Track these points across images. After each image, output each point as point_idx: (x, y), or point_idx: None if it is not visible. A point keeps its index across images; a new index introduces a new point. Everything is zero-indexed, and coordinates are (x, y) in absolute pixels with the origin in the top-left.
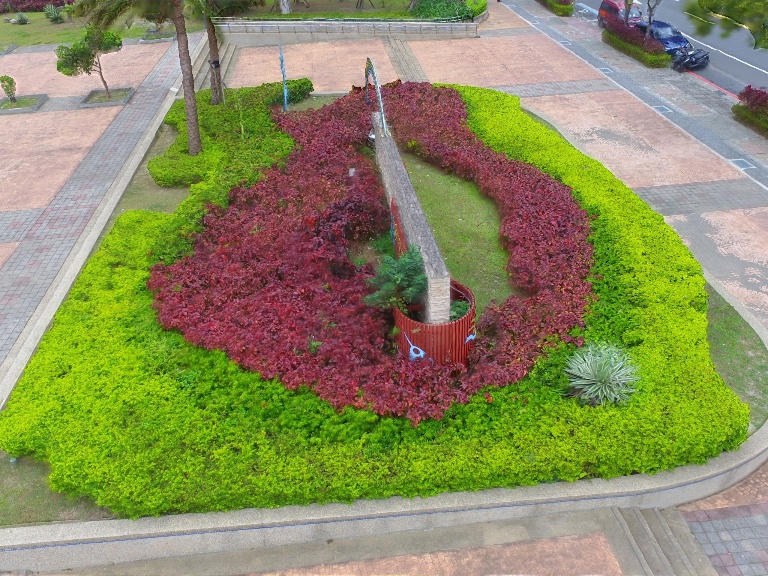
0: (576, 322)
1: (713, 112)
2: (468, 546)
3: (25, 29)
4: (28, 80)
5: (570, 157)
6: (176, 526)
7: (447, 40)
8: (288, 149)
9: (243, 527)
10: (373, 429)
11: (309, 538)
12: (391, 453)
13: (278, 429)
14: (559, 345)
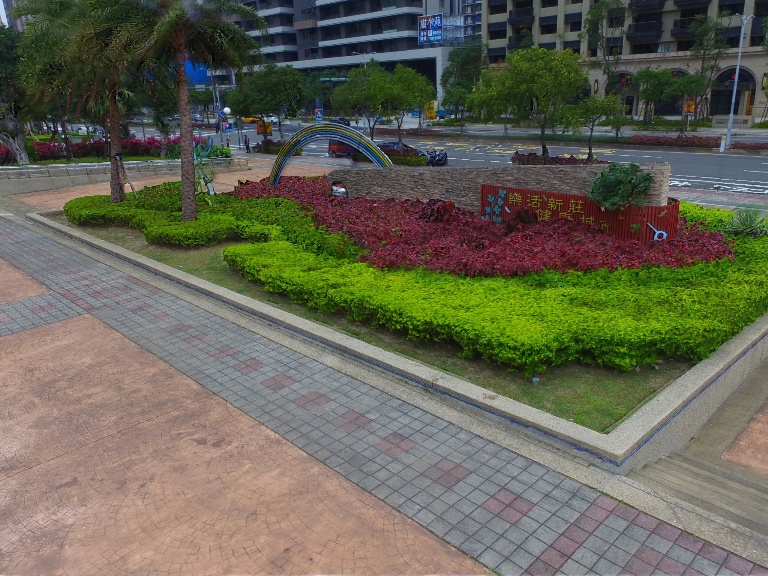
0: None
1: None
2: None
3: None
4: None
5: None
6: (736, 349)
7: (225, 173)
8: None
9: (759, 338)
10: None
11: None
12: (756, 270)
13: None
14: None
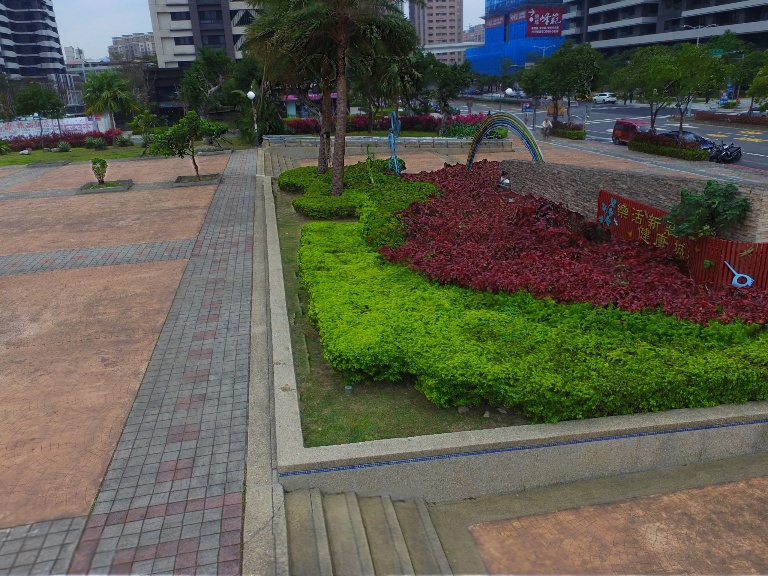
0: None
1: None
2: None
3: (70, 154)
4: None
5: None
6: (609, 426)
7: (486, 153)
8: (433, 188)
9: (685, 426)
10: None
11: (749, 448)
12: None
13: (657, 338)
14: None
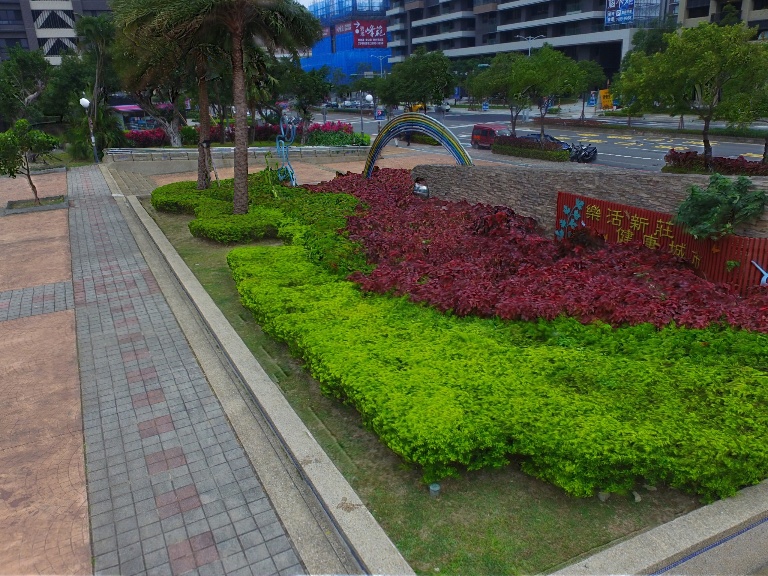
0: None
1: None
2: None
3: None
4: None
5: None
6: None
7: (356, 161)
8: None
9: None
10: None
11: None
12: None
13: None
14: None
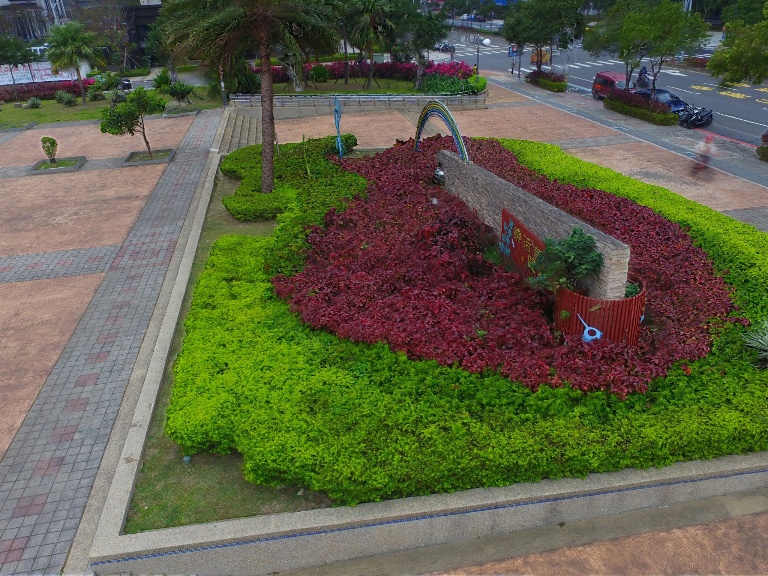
0: (732, 305)
1: (738, 155)
2: (715, 519)
3: (39, 111)
4: (59, 148)
5: (636, 185)
6: (402, 510)
7: (458, 111)
8: (363, 184)
9: (475, 508)
10: (578, 405)
11: (540, 521)
12: (613, 423)
13: (480, 408)
14: (726, 325)
